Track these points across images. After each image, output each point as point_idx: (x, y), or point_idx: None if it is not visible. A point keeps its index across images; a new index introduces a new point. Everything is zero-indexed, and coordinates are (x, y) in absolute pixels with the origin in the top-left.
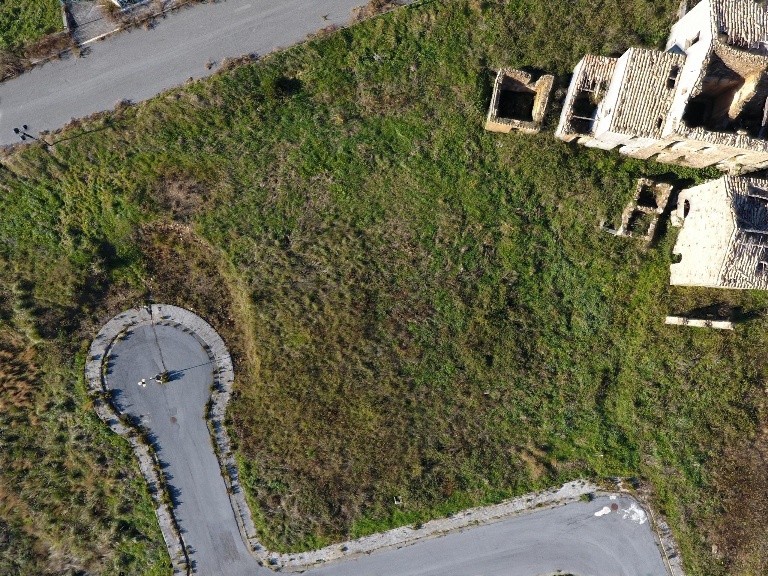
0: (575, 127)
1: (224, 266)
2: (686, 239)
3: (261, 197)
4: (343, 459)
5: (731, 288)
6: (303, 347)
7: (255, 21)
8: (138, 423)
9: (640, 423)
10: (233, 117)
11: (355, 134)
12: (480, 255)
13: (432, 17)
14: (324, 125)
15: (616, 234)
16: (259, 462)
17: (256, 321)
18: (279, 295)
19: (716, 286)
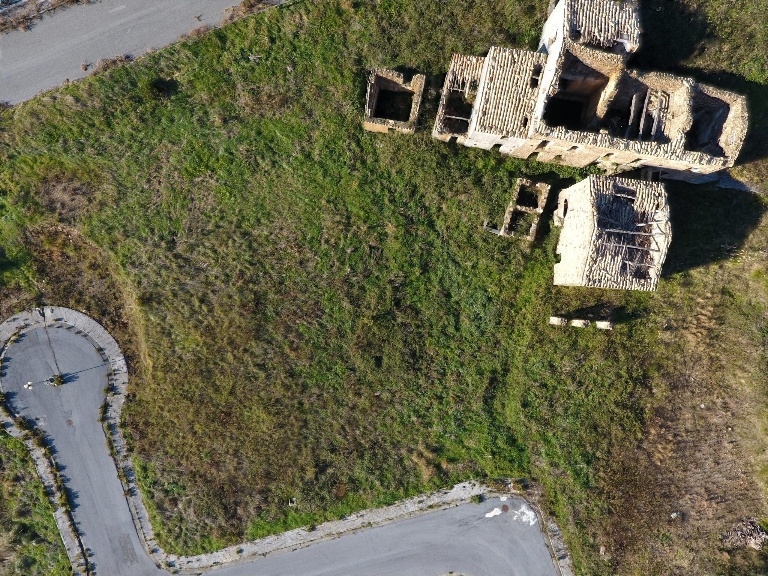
0: (454, 127)
1: (114, 268)
2: (564, 239)
3: (145, 198)
4: (238, 461)
5: (612, 288)
6: (194, 349)
7: (130, 22)
8: (34, 426)
9: (528, 424)
10: (113, 118)
11: (235, 135)
12: (367, 256)
13: (304, 17)
14: (204, 126)
15: (499, 234)
16: (155, 464)
17: (147, 323)
18: (168, 297)
19: None
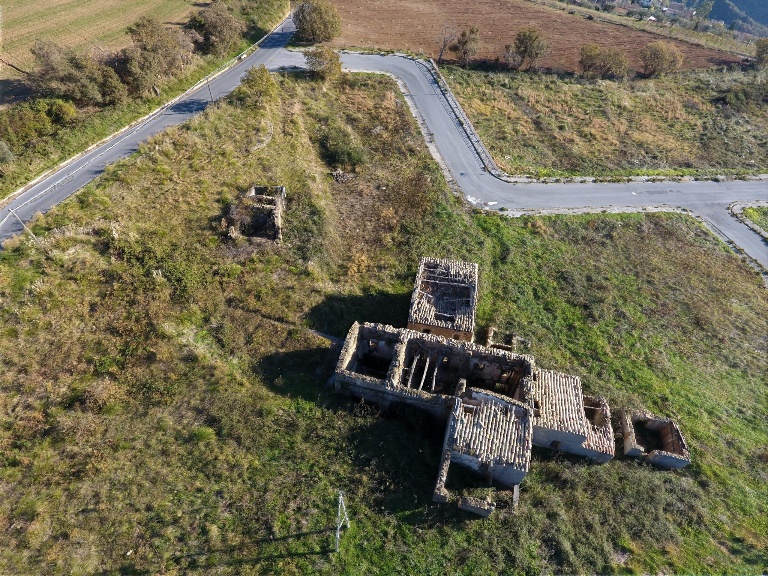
0: None
1: None
2: None
3: None
4: (666, 247)
5: None
6: None
7: None
8: None
9: None
10: None
11: None
12: (622, 341)
13: None
14: None
15: (517, 337)
16: (721, 253)
17: None
18: None
19: None
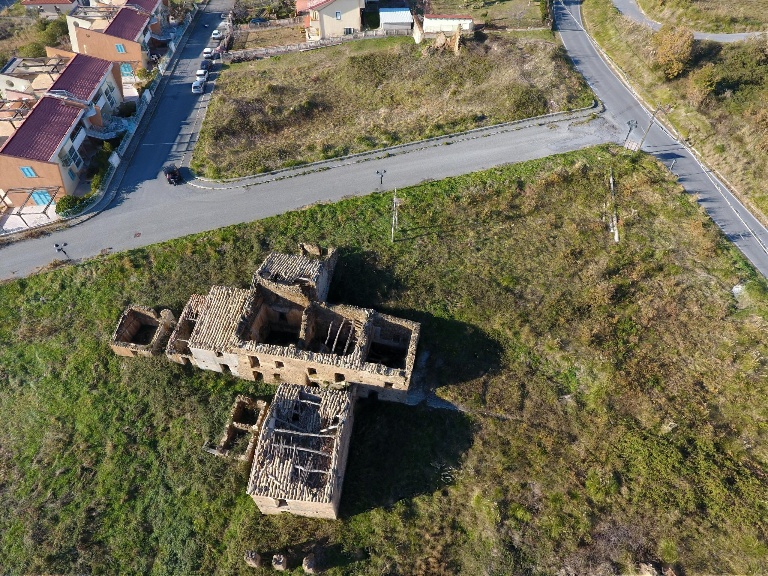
0: None
1: None
2: None
3: None
4: None
5: (321, 516)
6: None
7: None
8: None
9: None
10: None
11: None
12: (75, 479)
13: (94, 272)
14: None
15: (216, 454)
16: None
17: None
18: None
19: (292, 509)
